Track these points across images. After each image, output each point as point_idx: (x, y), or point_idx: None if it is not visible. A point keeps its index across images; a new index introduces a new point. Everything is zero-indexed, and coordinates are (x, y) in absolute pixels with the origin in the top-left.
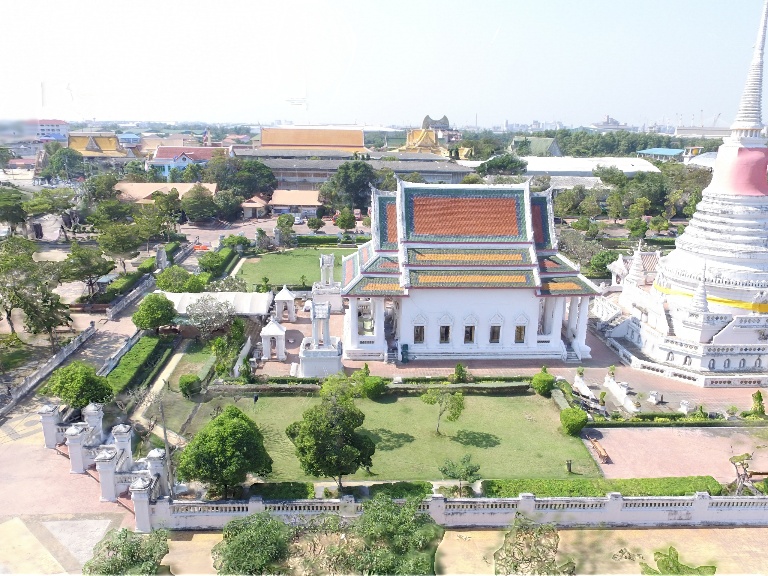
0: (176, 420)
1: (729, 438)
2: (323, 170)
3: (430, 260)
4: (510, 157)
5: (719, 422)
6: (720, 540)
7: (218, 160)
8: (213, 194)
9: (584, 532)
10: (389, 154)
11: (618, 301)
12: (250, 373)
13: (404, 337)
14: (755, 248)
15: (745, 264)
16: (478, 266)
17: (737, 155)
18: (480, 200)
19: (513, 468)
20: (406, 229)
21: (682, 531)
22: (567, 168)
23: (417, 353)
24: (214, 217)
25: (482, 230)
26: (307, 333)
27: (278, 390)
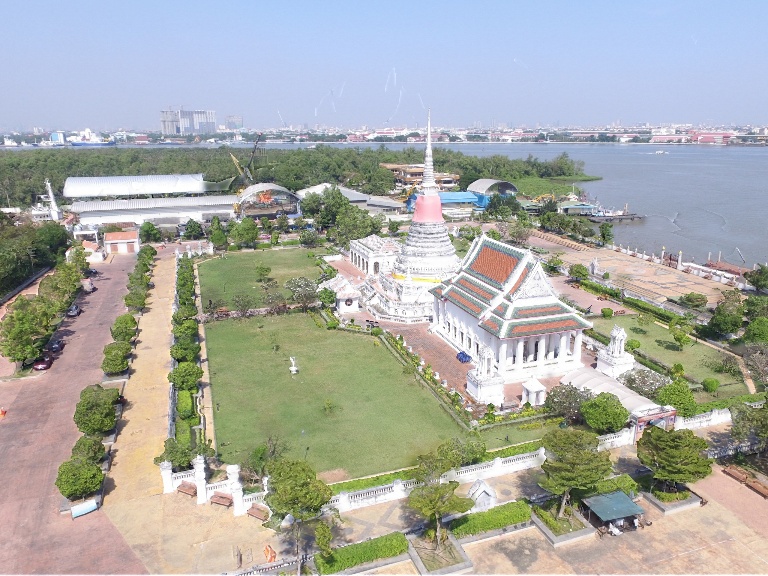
0: (736, 386)
1: None
2: None
3: None
4: None
5: None
6: None
7: None
8: None
9: None
10: None
11: None
12: None
13: None
14: None
15: None
16: None
17: None
18: None
19: None
20: None
21: None
22: None
23: None
24: None
25: None
26: None
27: None
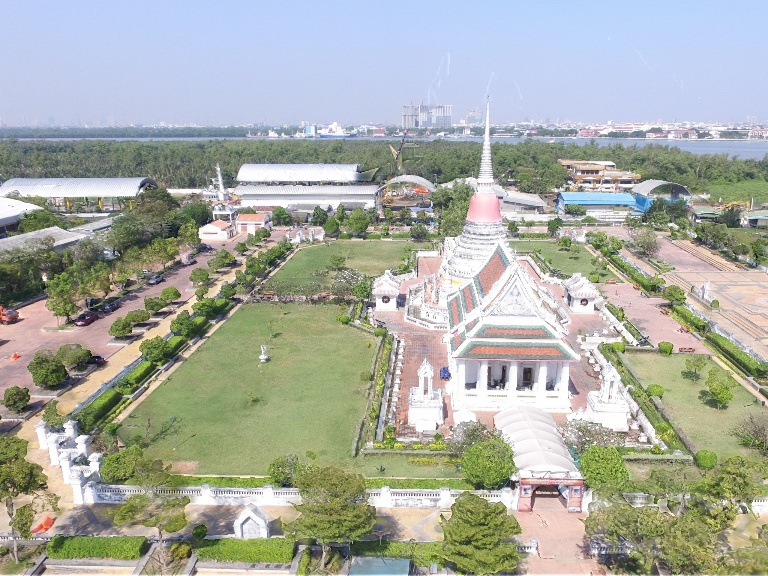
0: None
1: None
2: None
3: None
4: None
5: None
6: None
7: None
8: None
9: None
10: None
11: None
12: None
13: None
14: None
15: None
16: None
17: None
18: None
19: None
20: None
21: None
22: None
23: None
24: None
25: None
26: None
27: None
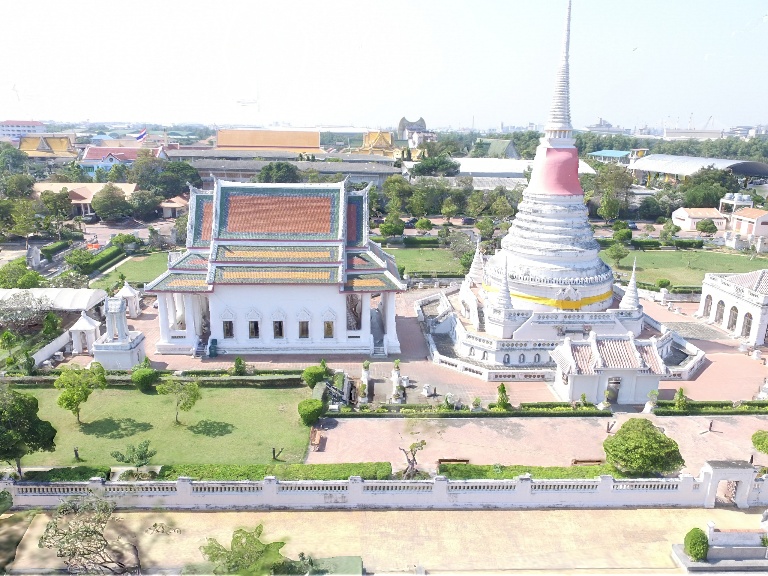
0: None
1: (459, 428)
2: (251, 171)
3: (238, 257)
4: (442, 158)
5: (461, 413)
6: (363, 522)
7: (142, 160)
8: (131, 194)
9: (238, 514)
10: (336, 155)
11: (458, 298)
12: (33, 365)
13: (214, 332)
14: (561, 246)
15: (552, 262)
16: (285, 263)
17: (546, 155)
18: (296, 199)
19: (223, 455)
20: (219, 227)
21: (334, 513)
22: (503, 169)
23: (227, 348)
24: (129, 217)
25: (295, 228)
26: (139, 329)
27: (53, 382)
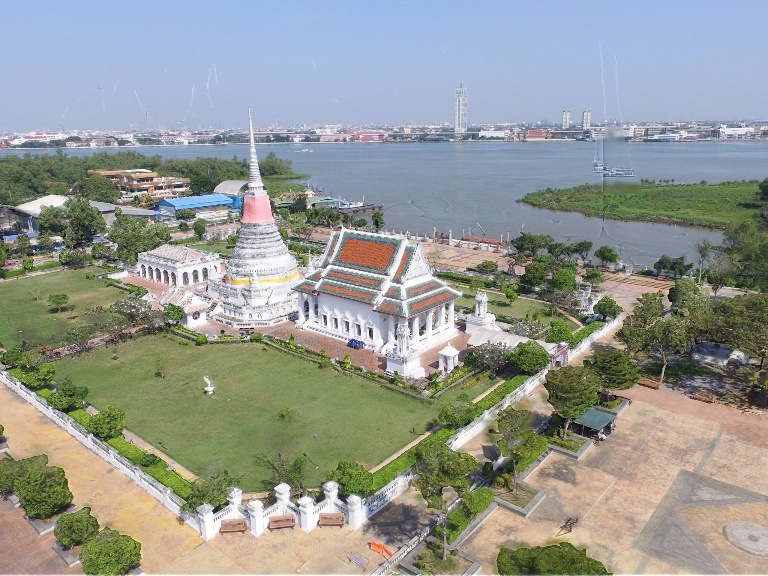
0: None
1: None
2: None
3: None
4: None
5: None
6: None
7: None
8: None
9: None
10: None
11: None
12: None
13: None
14: None
15: None
16: None
17: None
18: None
19: None
20: None
21: None
22: None
23: None
24: None
25: None
26: None
27: None
